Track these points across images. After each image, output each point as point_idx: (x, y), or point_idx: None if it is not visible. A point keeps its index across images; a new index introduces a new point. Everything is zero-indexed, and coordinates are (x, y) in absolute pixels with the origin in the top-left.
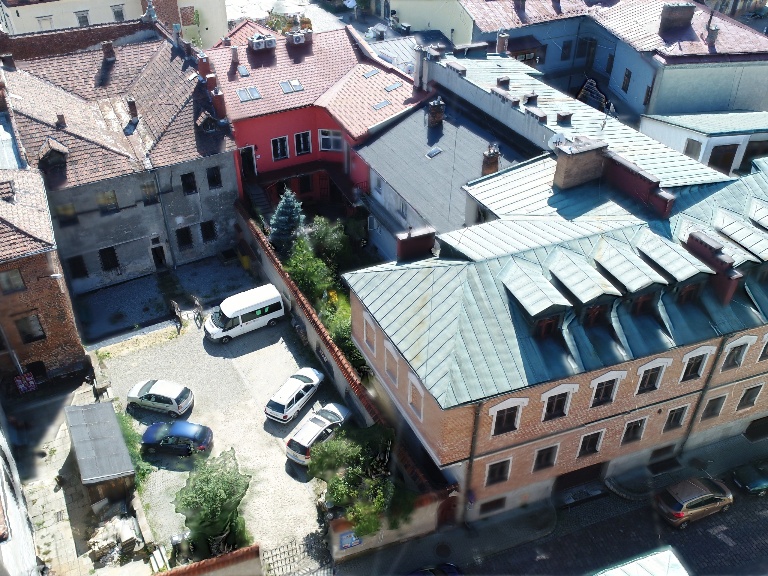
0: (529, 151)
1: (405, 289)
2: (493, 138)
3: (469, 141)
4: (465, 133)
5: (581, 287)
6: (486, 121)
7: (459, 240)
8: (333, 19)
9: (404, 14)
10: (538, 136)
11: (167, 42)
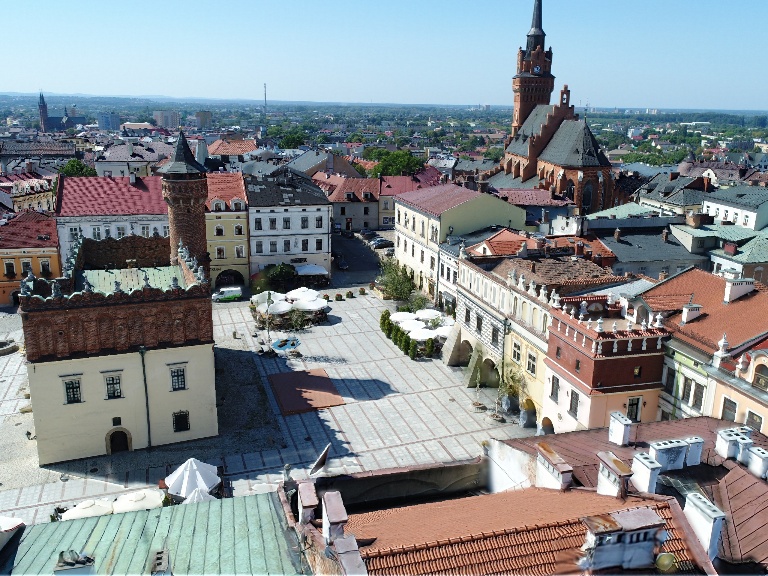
0: (661, 229)
1: (762, 251)
2: (642, 233)
3: (638, 238)
4: (631, 237)
5: (759, 233)
6: (633, 229)
7: (740, 238)
8: None
9: (458, 227)
10: (659, 223)
11: (510, 260)
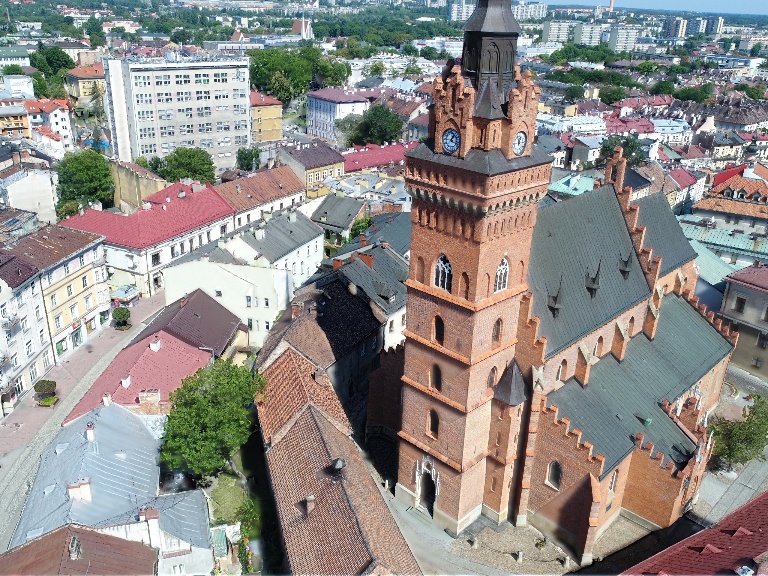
0: None
1: None
2: None
3: None
4: None
5: None
6: None
7: None
8: None
9: None
10: None
11: None
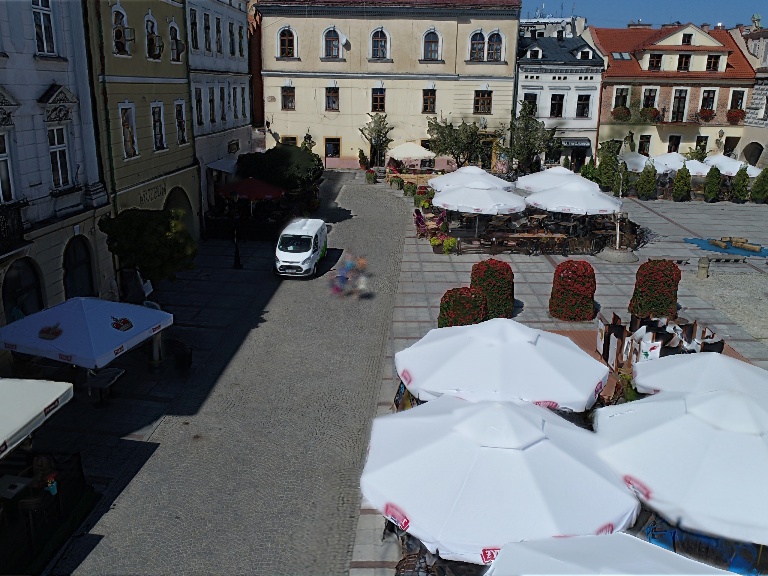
0: None
1: None
2: None
3: None
4: None
5: None
6: None
7: None
8: (220, 422)
9: None
10: None
11: None
